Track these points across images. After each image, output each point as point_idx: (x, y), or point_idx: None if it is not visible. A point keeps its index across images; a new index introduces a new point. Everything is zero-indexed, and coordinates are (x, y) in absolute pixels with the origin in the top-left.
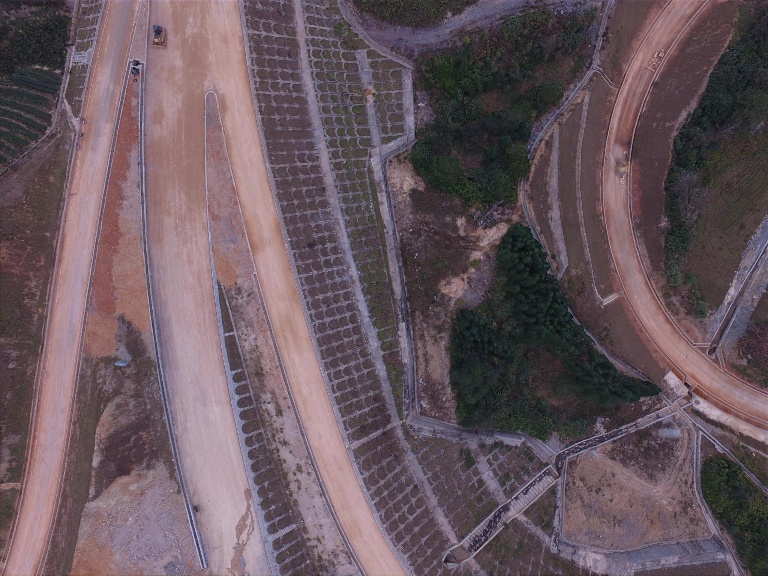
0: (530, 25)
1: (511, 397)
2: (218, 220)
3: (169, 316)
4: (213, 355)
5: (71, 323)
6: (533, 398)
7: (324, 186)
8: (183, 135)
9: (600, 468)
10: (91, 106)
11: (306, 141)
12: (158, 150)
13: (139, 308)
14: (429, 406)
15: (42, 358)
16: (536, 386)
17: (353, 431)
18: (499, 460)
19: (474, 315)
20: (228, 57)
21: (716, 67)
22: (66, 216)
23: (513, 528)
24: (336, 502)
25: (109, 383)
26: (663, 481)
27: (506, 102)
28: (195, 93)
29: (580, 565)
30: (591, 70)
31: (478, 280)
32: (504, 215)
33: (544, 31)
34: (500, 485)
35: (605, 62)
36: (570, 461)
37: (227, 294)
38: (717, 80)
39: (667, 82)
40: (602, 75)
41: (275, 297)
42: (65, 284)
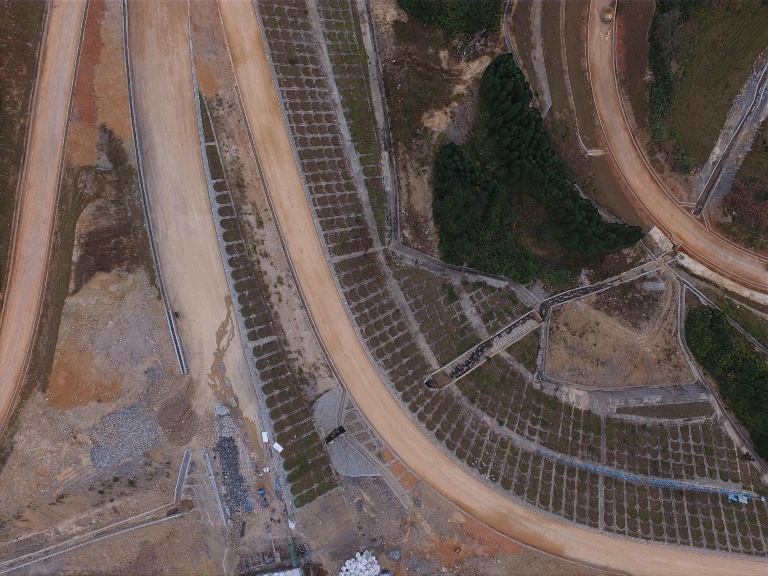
0: None
1: (494, 238)
2: (200, 31)
3: (150, 126)
4: (194, 164)
5: (53, 134)
6: (517, 245)
7: (306, 10)
8: None
9: (584, 317)
10: None
11: None
12: None
13: (121, 117)
14: (412, 237)
15: (24, 168)
16: (520, 232)
17: (334, 246)
18: (482, 299)
19: (456, 145)
20: None
21: None
22: (48, 28)
23: (496, 363)
24: (317, 316)
25: (90, 187)
26: (647, 329)
27: None
28: None
29: (563, 401)
30: None
31: (461, 116)
32: (487, 48)
33: None
34: (483, 322)
35: None
36: (554, 310)
37: (208, 105)
38: None
39: None
40: None
41: (256, 109)
42: (47, 96)
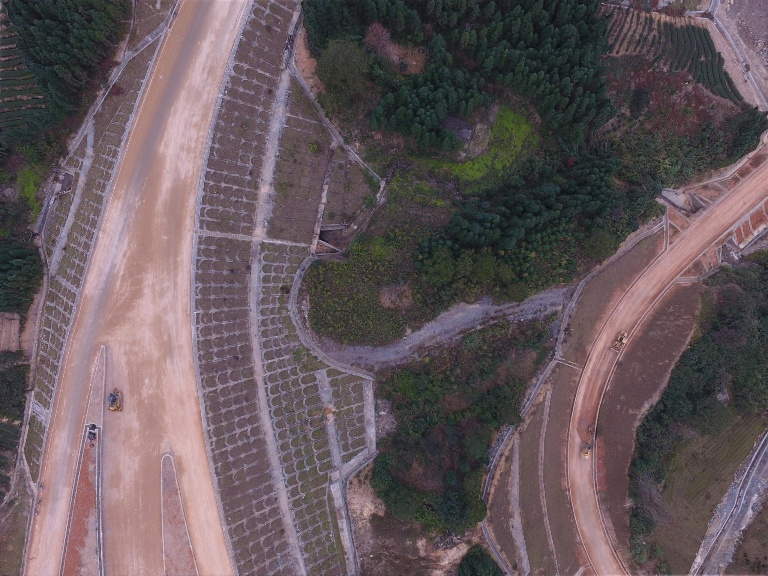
0: (489, 340)
1: None
2: None
3: None
4: None
5: None
6: None
7: (283, 527)
8: (140, 498)
9: None
10: (49, 470)
11: (264, 485)
12: (115, 514)
13: None
14: None
15: None
16: None
17: None
18: None
19: None
20: (184, 418)
21: (678, 363)
22: None
23: None
24: None
25: None
26: None
27: (468, 401)
28: (151, 456)
29: None
30: (554, 360)
31: None
32: (464, 537)
33: (504, 339)
34: None
35: (567, 353)
36: None
37: None
38: (678, 378)
39: (631, 364)
40: (565, 362)
41: None
42: None
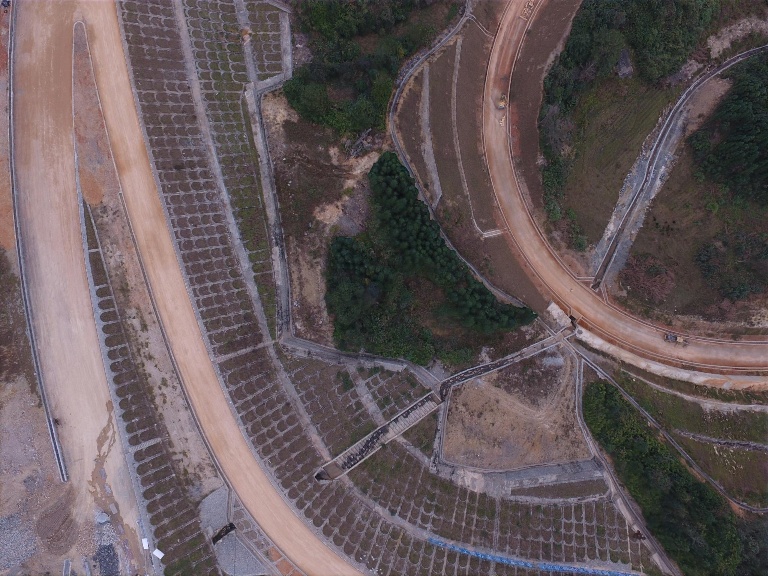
0: None
1: (391, 323)
2: (84, 142)
3: (34, 234)
4: (77, 271)
5: None
6: (416, 327)
7: (195, 114)
8: (52, 62)
9: (485, 395)
10: None
11: (177, 72)
12: (27, 77)
13: (4, 226)
14: (304, 328)
15: None
16: (418, 315)
17: (219, 346)
18: (379, 384)
19: (346, 238)
20: None
21: (578, 12)
22: None
23: (391, 449)
24: (202, 416)
25: None
26: (545, 406)
27: None
28: (64, 23)
29: (459, 485)
30: (464, 17)
31: (353, 208)
32: (374, 144)
33: None
34: (379, 408)
35: (477, 10)
36: (455, 389)
37: (93, 212)
38: (579, 23)
39: (538, 30)
40: (476, 22)
41: (141, 215)
42: None
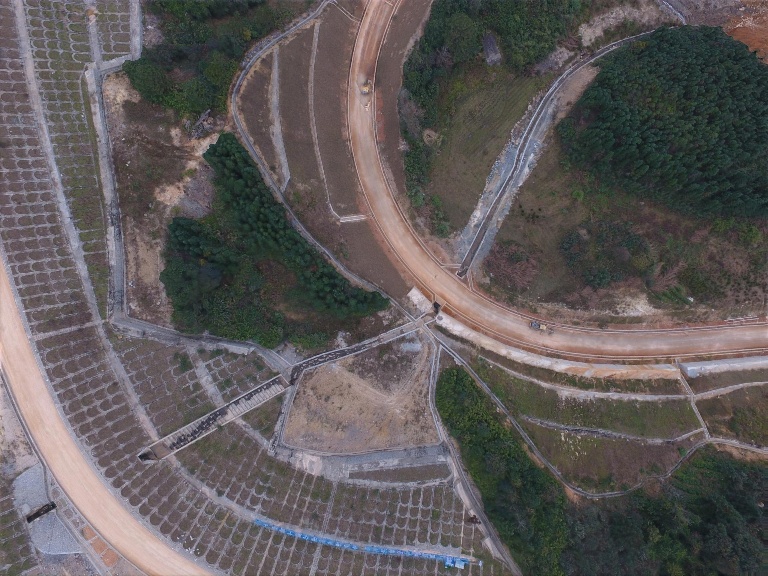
0: None
1: (237, 306)
2: None
3: None
4: None
5: None
6: (268, 311)
7: (28, 93)
8: None
9: (337, 380)
10: None
11: (9, 50)
12: None
13: None
14: (139, 309)
15: None
16: (269, 298)
17: (39, 323)
18: (221, 366)
19: (182, 219)
20: None
21: None
22: None
23: (228, 431)
24: (18, 393)
25: None
26: (397, 391)
27: None
28: None
29: (296, 467)
30: (326, 1)
31: (196, 190)
32: (216, 126)
33: None
34: (219, 390)
35: None
36: (307, 373)
37: None
38: (436, 8)
39: (403, 15)
40: (338, 7)
41: None
42: None
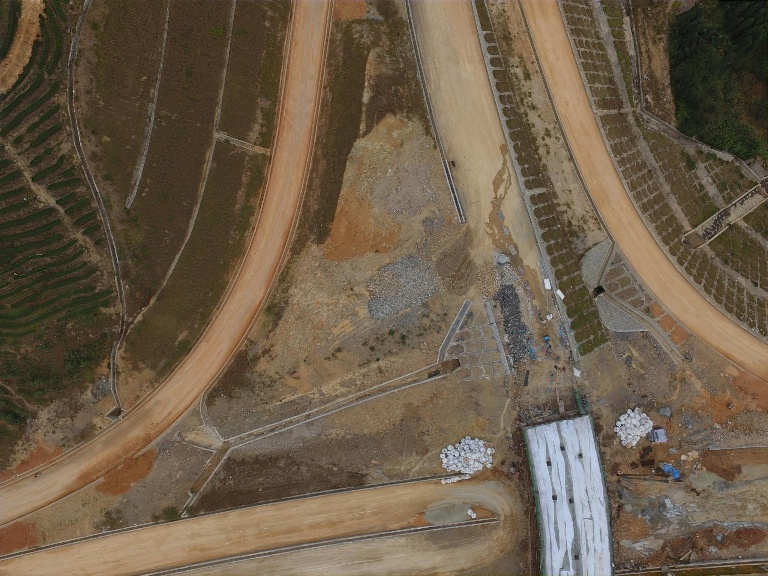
0: None
1: None
2: None
3: None
4: (464, 16)
5: None
6: None
7: None
8: None
9: None
10: None
11: None
12: None
13: None
14: (653, 102)
15: (291, 25)
16: (741, 108)
17: (598, 100)
18: (714, 170)
19: None
20: None
21: None
22: None
23: (736, 230)
24: (584, 169)
25: (367, 36)
26: None
27: None
28: None
29: None
30: None
31: None
32: None
33: None
34: (719, 191)
35: None
36: None
37: None
38: None
39: None
40: None
41: None
42: None
